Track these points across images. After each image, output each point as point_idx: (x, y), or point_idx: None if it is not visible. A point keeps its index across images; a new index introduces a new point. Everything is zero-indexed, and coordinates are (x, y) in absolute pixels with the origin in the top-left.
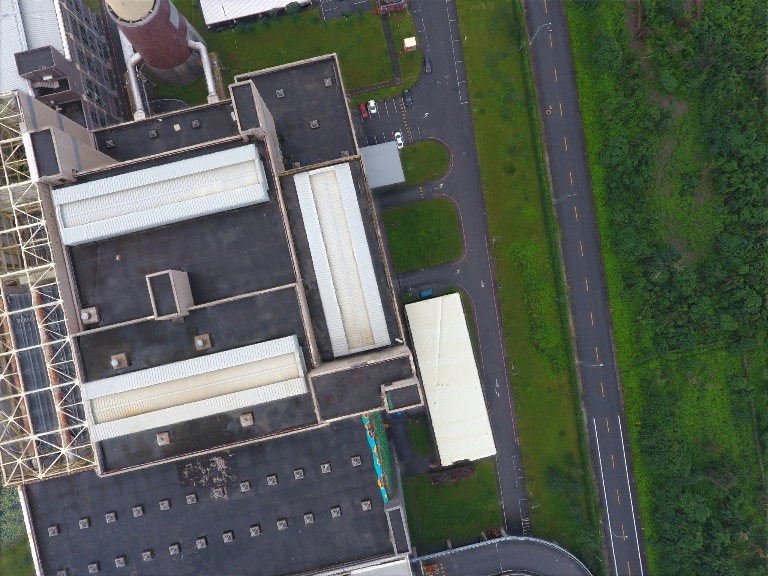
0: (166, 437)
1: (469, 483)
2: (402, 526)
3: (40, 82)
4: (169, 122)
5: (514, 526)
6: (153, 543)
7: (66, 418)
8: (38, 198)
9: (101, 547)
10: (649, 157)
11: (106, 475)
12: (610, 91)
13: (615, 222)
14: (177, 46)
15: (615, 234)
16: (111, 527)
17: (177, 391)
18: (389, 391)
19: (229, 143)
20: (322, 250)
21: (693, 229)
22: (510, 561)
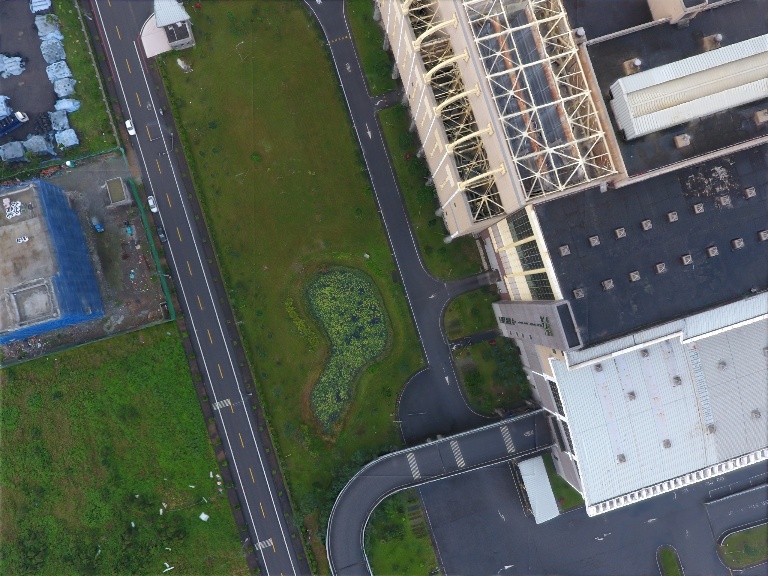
0: None
1: None
2: None
3: None
4: None
5: None
6: (663, 256)
7: None
8: None
9: (612, 264)
10: None
11: (633, 178)
12: None
13: None
14: None
15: None
16: (620, 243)
17: (710, 81)
18: None
19: None
20: None
21: None
22: None
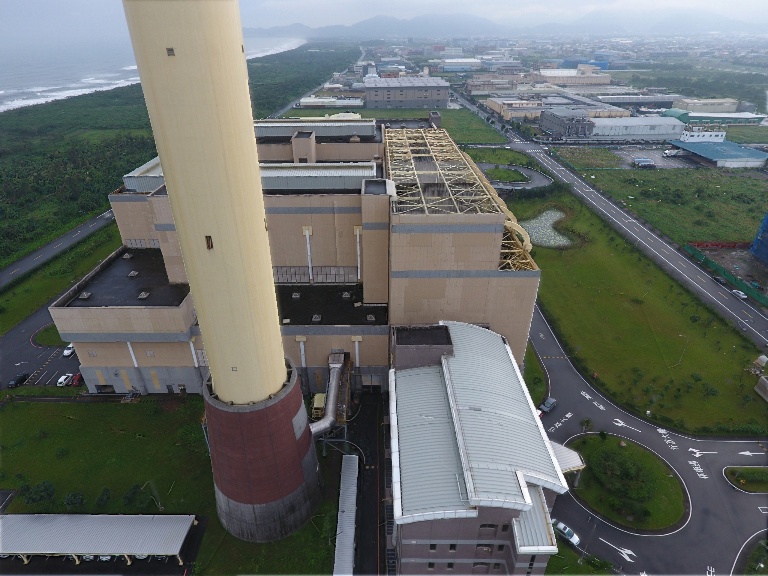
0: None
1: None
2: None
3: None
4: None
5: None
6: None
7: None
8: None
9: None
10: None
11: (379, 124)
12: None
13: None
14: None
15: None
16: None
17: None
18: None
19: None
20: None
21: None
22: None
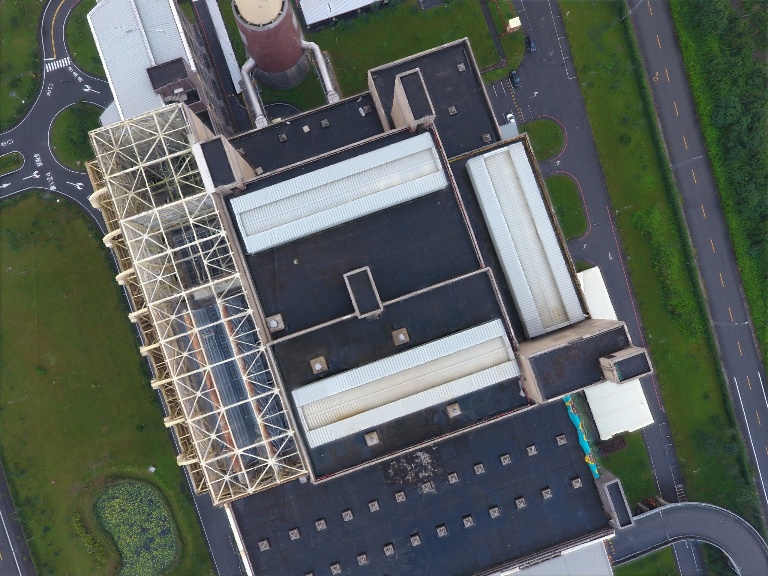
0: (375, 436)
1: (620, 456)
2: (622, 499)
3: (170, 96)
4: (297, 124)
5: (669, 493)
6: (366, 546)
7: (266, 429)
8: (215, 209)
9: (314, 556)
10: (761, 113)
11: (320, 482)
12: (716, 52)
13: (735, 181)
14: (294, 47)
15: (735, 193)
16: (322, 535)
17: (388, 388)
18: (617, 362)
19: (397, 135)
20: (506, 232)
21: None
22: (675, 528)
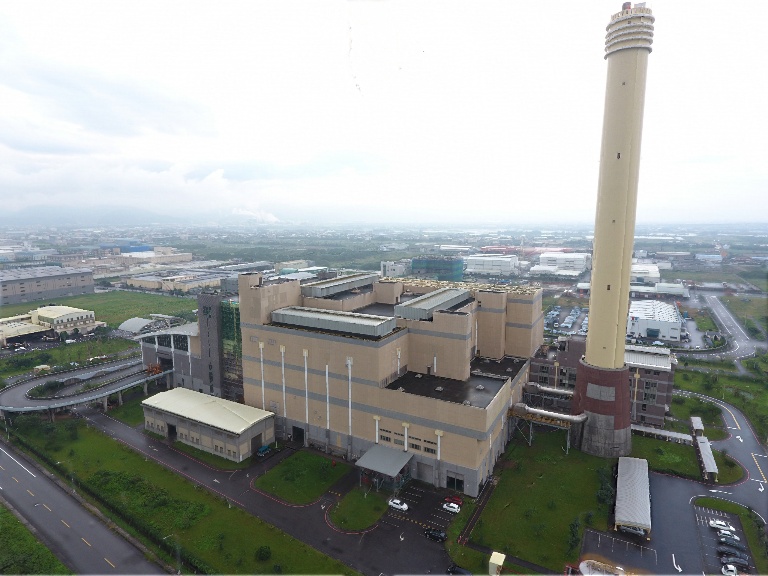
0: None
1: None
2: None
3: None
4: None
5: None
6: None
7: None
8: None
9: None
10: None
11: None
12: None
13: None
14: None
15: None
16: None
17: None
18: None
19: None
20: None
21: None
22: None
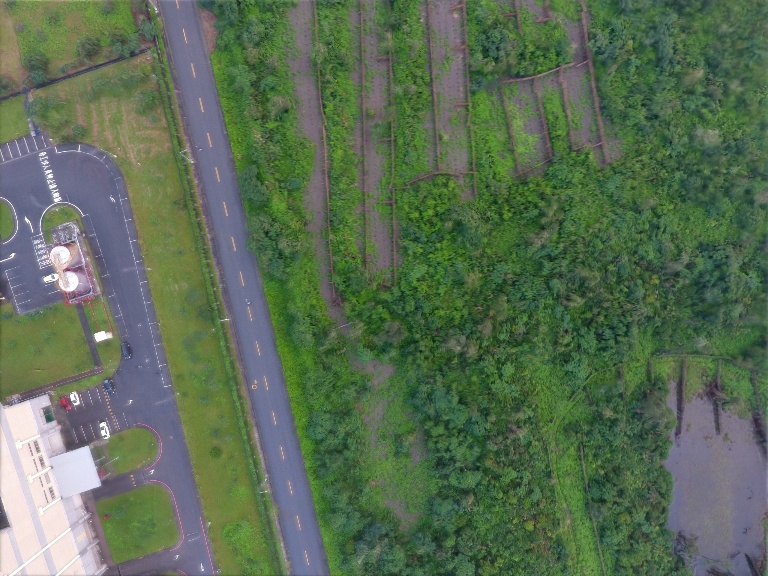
0: None
1: None
2: None
3: None
4: None
5: None
6: None
7: None
8: None
9: None
10: (354, 429)
11: None
12: (309, 366)
13: None
14: None
15: (329, 507)
16: None
17: None
18: None
19: None
20: None
21: (411, 491)
22: None
